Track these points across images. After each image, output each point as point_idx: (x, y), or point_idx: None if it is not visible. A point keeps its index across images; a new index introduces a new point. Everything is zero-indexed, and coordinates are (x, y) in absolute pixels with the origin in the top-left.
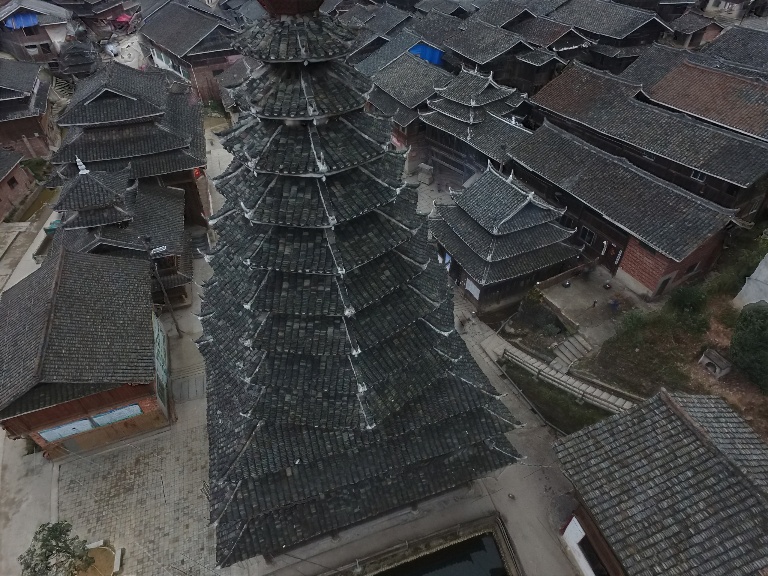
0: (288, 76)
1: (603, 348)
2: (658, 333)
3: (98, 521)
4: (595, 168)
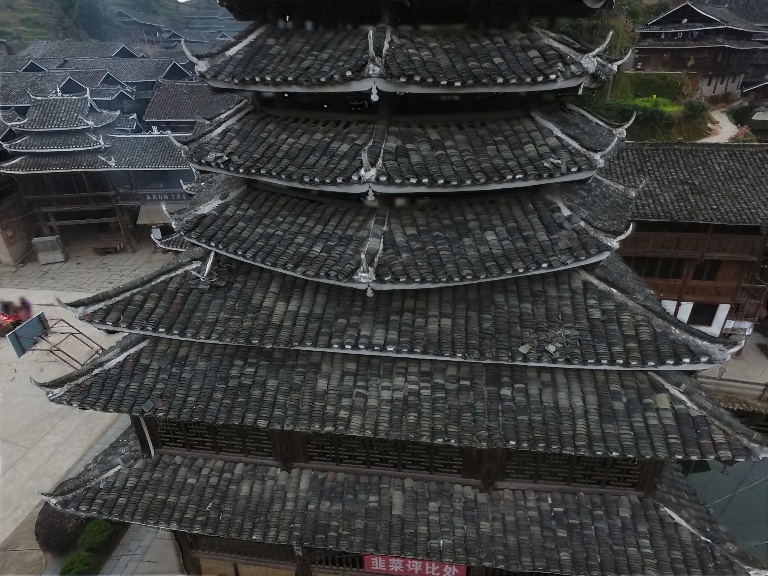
0: None
1: None
2: None
3: None
4: None
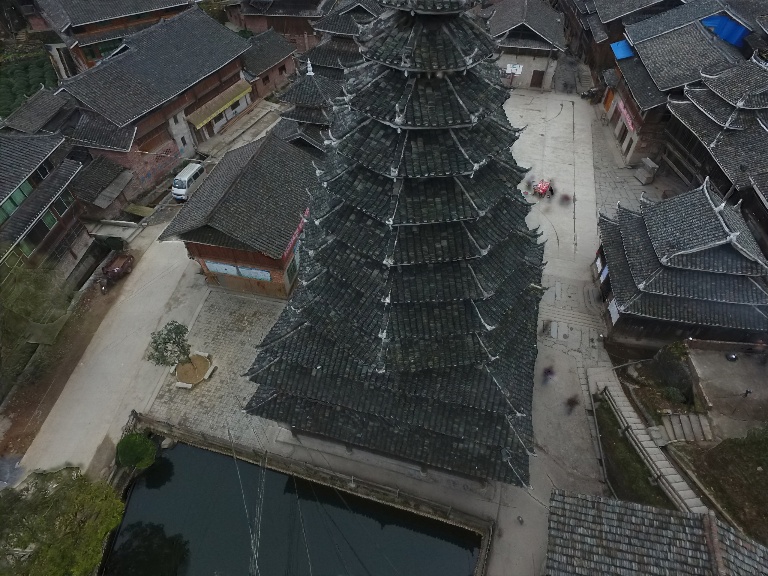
0: (405, 23)
1: (720, 444)
2: None
3: (213, 340)
4: None
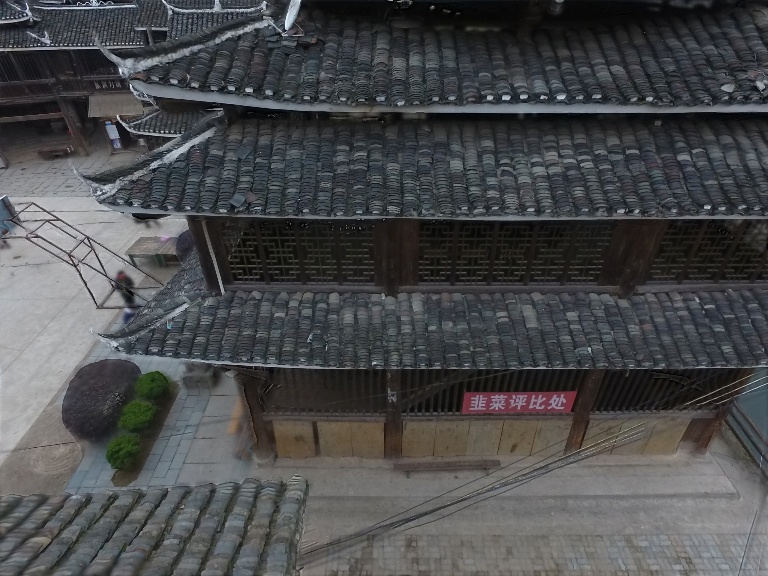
0: None
1: None
2: None
3: None
4: (257, 0)
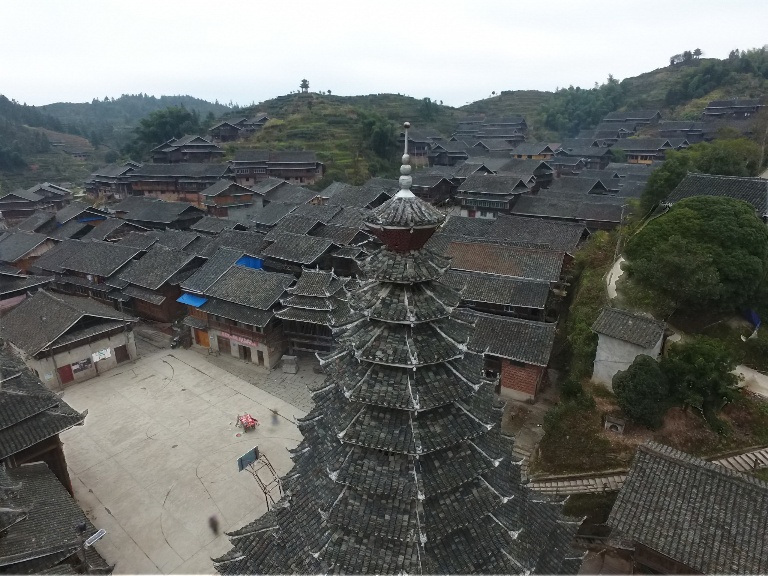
0: (413, 290)
1: (543, 447)
2: (572, 419)
3: None
4: None
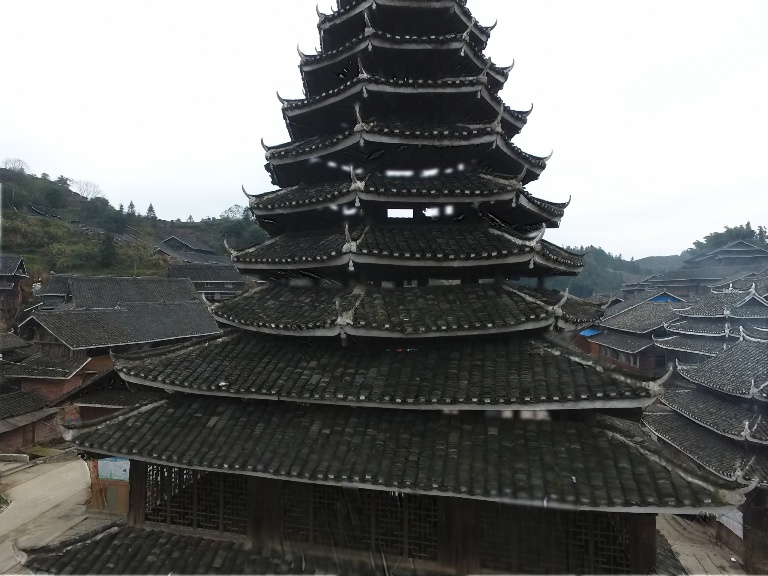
0: None
1: None
2: None
3: None
4: None
